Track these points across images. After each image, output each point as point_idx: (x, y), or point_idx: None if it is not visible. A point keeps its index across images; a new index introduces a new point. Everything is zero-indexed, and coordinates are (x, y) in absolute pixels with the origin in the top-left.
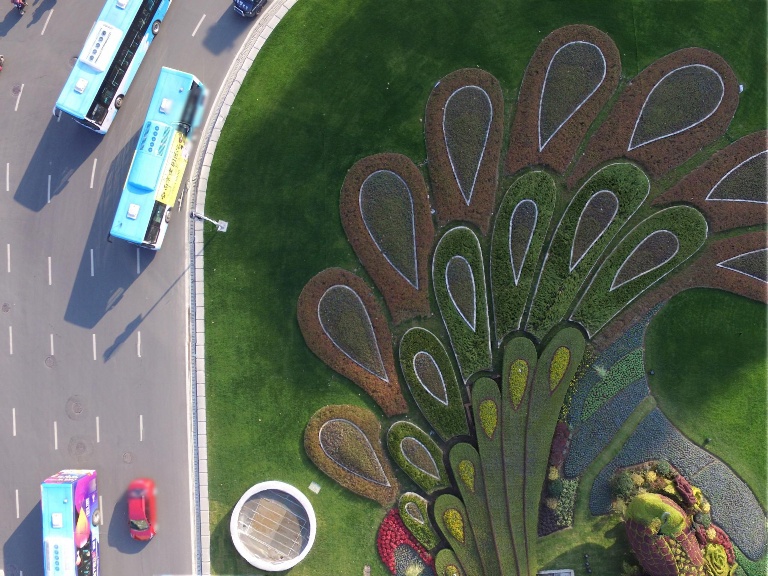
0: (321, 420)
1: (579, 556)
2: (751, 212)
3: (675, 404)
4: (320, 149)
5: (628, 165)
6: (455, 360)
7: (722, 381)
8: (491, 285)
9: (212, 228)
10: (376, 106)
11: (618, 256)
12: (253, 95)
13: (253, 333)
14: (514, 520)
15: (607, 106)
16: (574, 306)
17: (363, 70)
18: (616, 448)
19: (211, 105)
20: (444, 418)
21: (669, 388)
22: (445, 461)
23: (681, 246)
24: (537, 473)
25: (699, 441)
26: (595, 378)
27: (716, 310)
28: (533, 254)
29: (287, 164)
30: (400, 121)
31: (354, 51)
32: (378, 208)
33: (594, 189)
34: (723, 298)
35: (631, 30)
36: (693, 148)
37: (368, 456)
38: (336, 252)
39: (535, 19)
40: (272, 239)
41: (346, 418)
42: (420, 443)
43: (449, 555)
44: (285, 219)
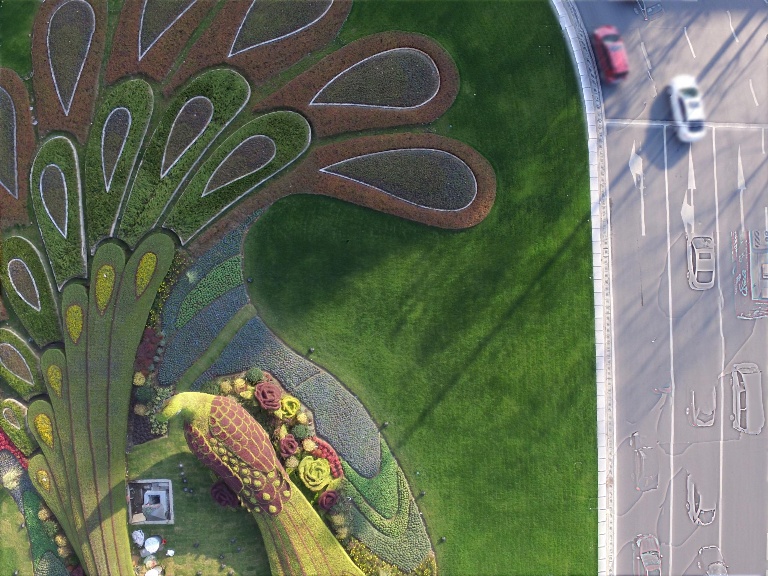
0: None
1: (175, 466)
2: (358, 116)
3: (276, 313)
4: None
5: (226, 71)
6: (51, 268)
7: (327, 290)
8: None
9: None
10: None
11: (212, 162)
12: None
13: None
14: (95, 424)
15: (211, 14)
16: (169, 213)
17: None
18: (212, 357)
19: None
20: (36, 324)
21: (269, 296)
22: None
23: (278, 150)
24: (122, 379)
25: (302, 351)
26: (190, 285)
27: (321, 217)
28: (125, 161)
29: None
30: (11, 37)
31: None
32: None
33: (188, 95)
34: (328, 204)
35: None
36: (298, 52)
37: None
38: None
39: None
40: None
41: None
42: (15, 349)
43: (41, 460)
44: None
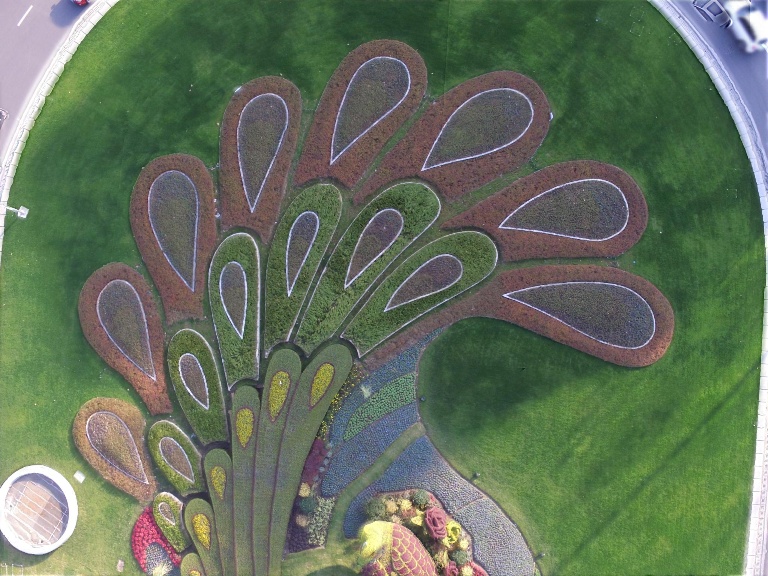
0: (89, 411)
1: None
2: (546, 244)
3: (445, 434)
4: (120, 145)
5: (418, 185)
6: (222, 365)
7: (498, 416)
8: (265, 294)
9: (14, 213)
10: (177, 107)
11: (397, 277)
12: (67, 88)
13: (37, 319)
14: (258, 532)
15: (406, 124)
16: (348, 323)
17: (170, 71)
18: (378, 472)
19: (32, 94)
20: (203, 422)
21: (440, 417)
22: (203, 465)
23: (464, 272)
24: (288, 488)
25: (468, 475)
26: (362, 398)
27: (499, 342)
28: (309, 267)
29: (88, 157)
30: (198, 123)
31: (164, 51)
32: (164, 207)
33: (379, 207)
34: (508, 330)
35: (443, 49)
36: (491, 173)
37: (129, 451)
38: (121, 247)
39: (345, 31)
40: (65, 229)
41: (112, 411)
42: (178, 444)
43: (195, 560)
44: (79, 210)
